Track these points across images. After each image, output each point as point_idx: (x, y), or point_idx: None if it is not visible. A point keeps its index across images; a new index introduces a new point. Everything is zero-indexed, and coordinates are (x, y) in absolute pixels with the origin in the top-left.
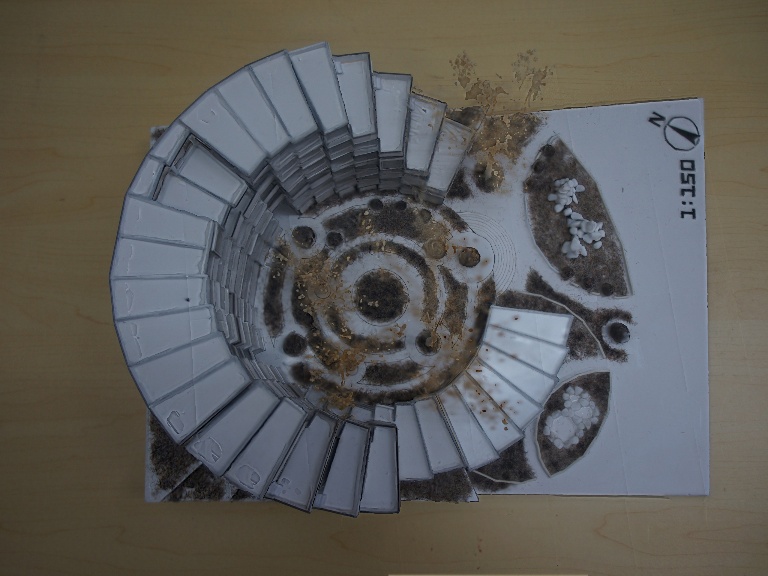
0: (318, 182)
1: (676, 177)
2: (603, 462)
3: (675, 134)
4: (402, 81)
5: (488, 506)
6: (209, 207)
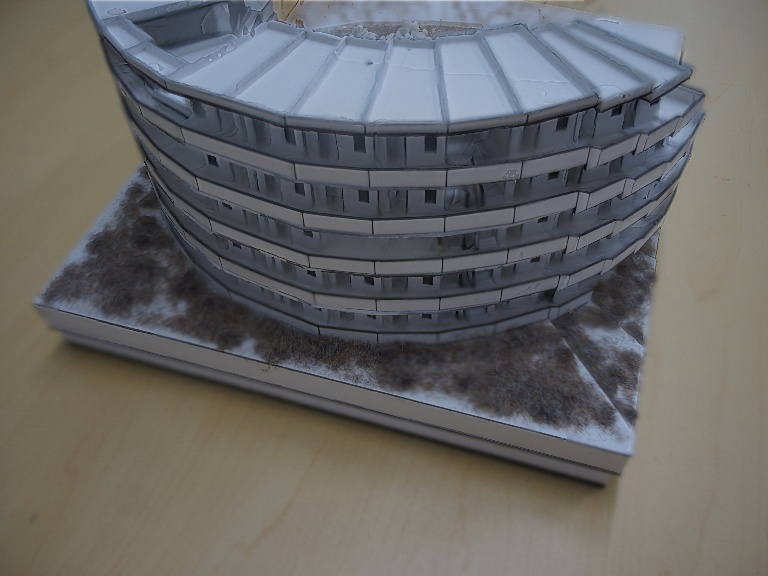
0: None
1: None
2: None
3: None
4: None
5: None
6: None
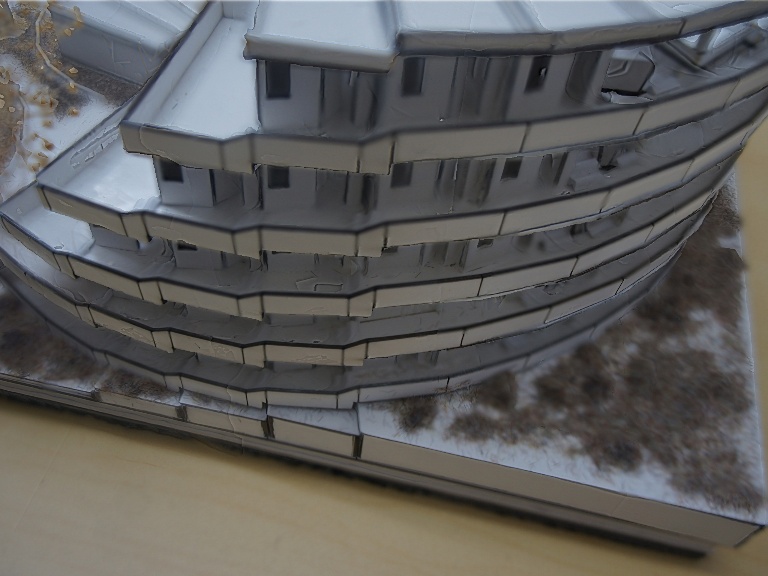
0: None
1: None
2: None
3: None
4: (70, 206)
5: None
6: None
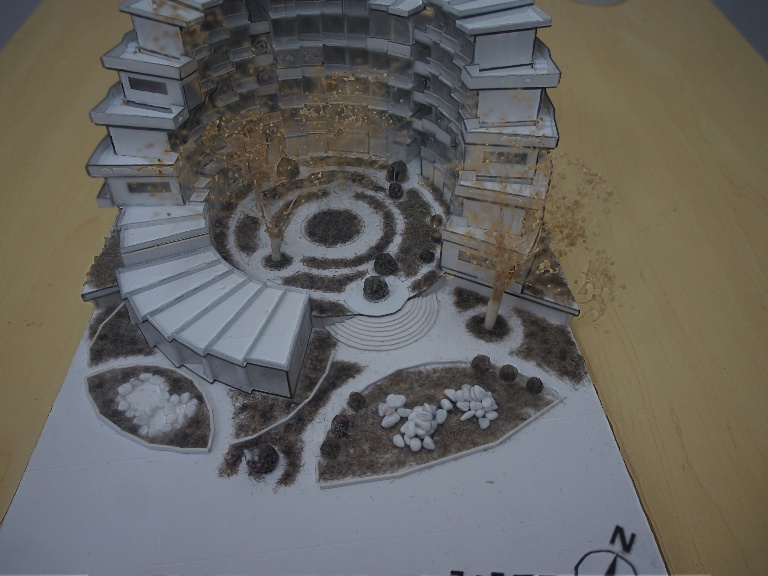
0: (442, 136)
1: (525, 568)
2: (83, 441)
3: (603, 567)
4: None
5: (77, 332)
6: (387, 3)
